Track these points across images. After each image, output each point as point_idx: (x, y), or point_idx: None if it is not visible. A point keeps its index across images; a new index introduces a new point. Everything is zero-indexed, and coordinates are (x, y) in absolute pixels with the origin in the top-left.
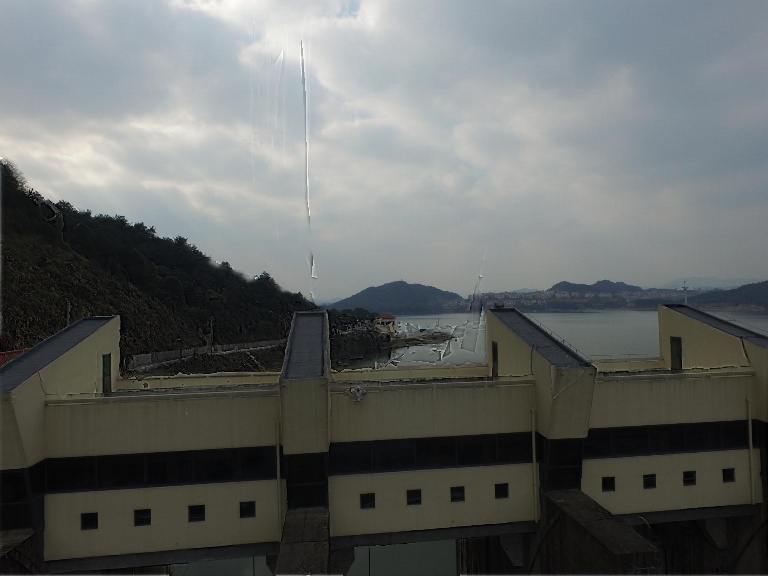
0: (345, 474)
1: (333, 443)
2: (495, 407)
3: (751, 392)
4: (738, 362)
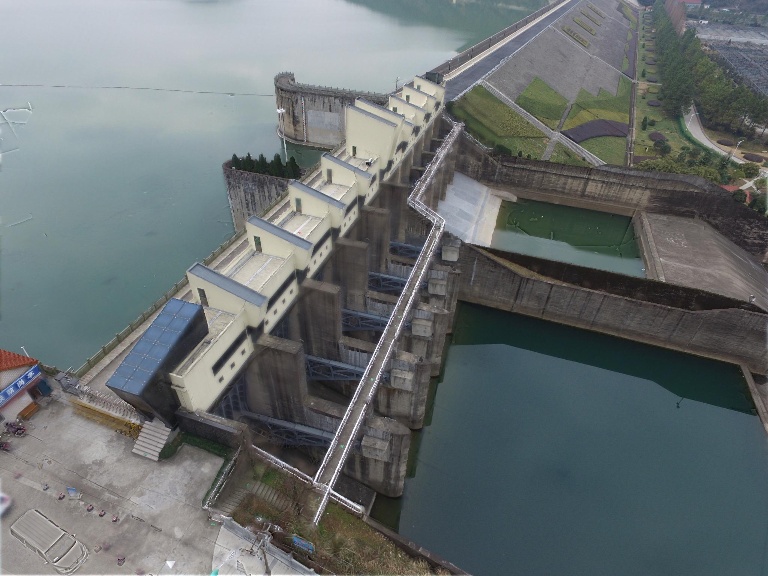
0: None
1: None
2: None
3: (357, 188)
4: (353, 179)
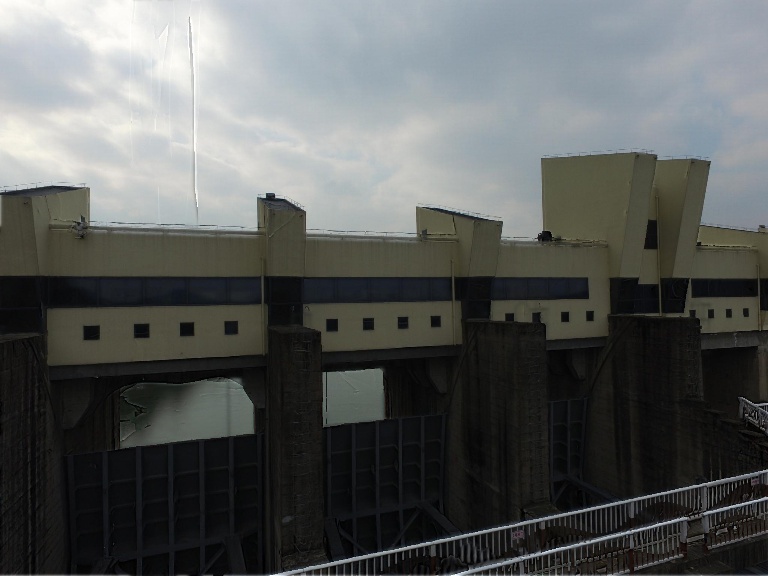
0: (68, 307)
1: (55, 277)
2: (227, 253)
3: (455, 255)
4: None
